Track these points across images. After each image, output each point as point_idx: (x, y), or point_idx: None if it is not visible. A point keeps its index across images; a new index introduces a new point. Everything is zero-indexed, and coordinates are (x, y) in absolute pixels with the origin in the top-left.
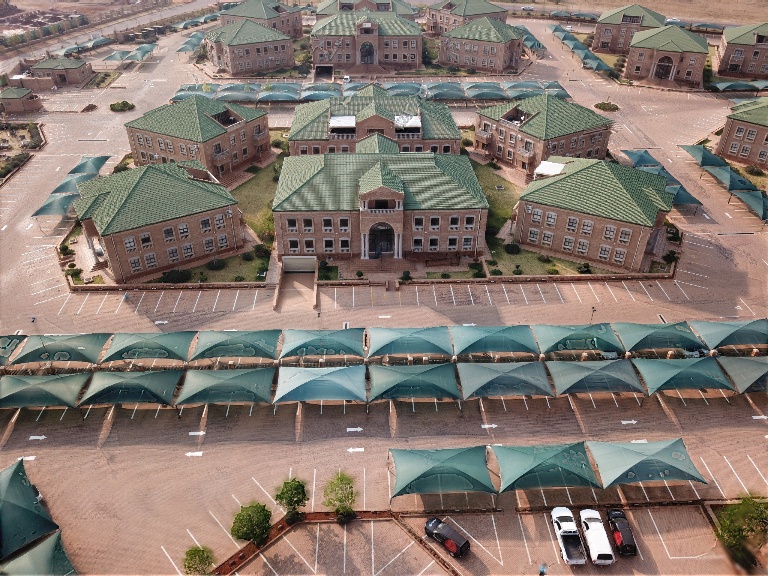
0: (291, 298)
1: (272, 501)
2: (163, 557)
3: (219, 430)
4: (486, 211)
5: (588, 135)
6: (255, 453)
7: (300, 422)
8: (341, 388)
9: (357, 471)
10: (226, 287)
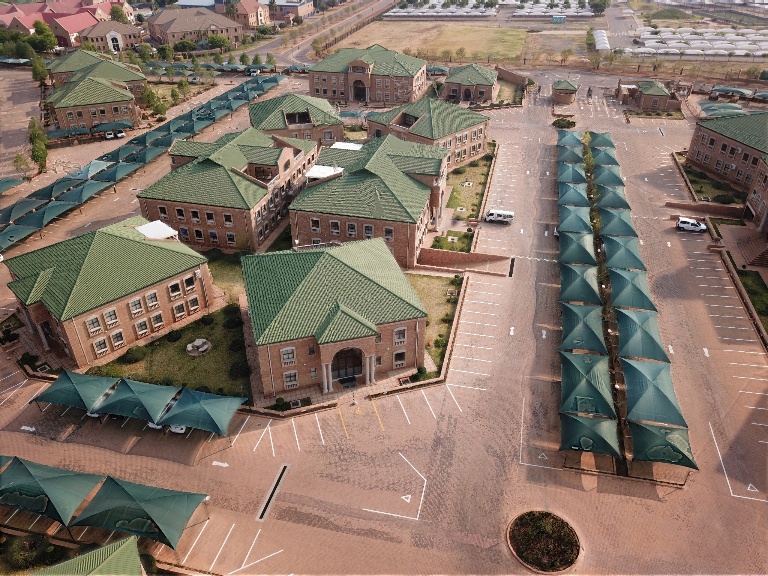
0: None
1: None
2: None
3: None
4: (139, 199)
5: (75, 168)
6: None
7: None
8: None
9: (43, 184)
10: None
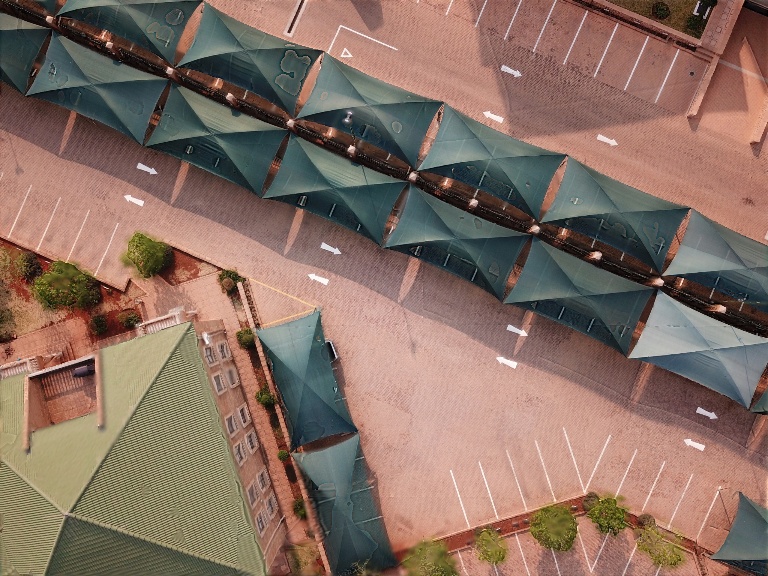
0: (725, 93)
1: (576, 469)
2: (450, 483)
3: (544, 338)
4: None
5: None
6: (577, 394)
7: (646, 371)
8: (728, 380)
9: (683, 475)
10: (631, 21)
